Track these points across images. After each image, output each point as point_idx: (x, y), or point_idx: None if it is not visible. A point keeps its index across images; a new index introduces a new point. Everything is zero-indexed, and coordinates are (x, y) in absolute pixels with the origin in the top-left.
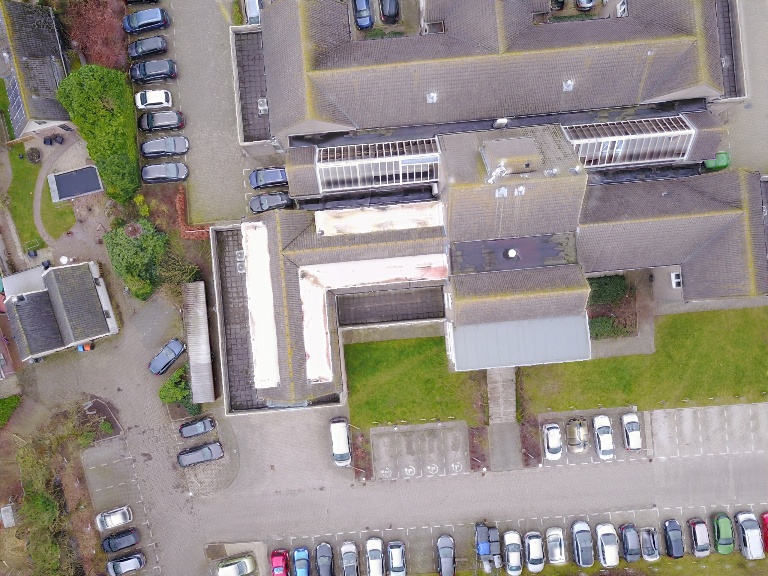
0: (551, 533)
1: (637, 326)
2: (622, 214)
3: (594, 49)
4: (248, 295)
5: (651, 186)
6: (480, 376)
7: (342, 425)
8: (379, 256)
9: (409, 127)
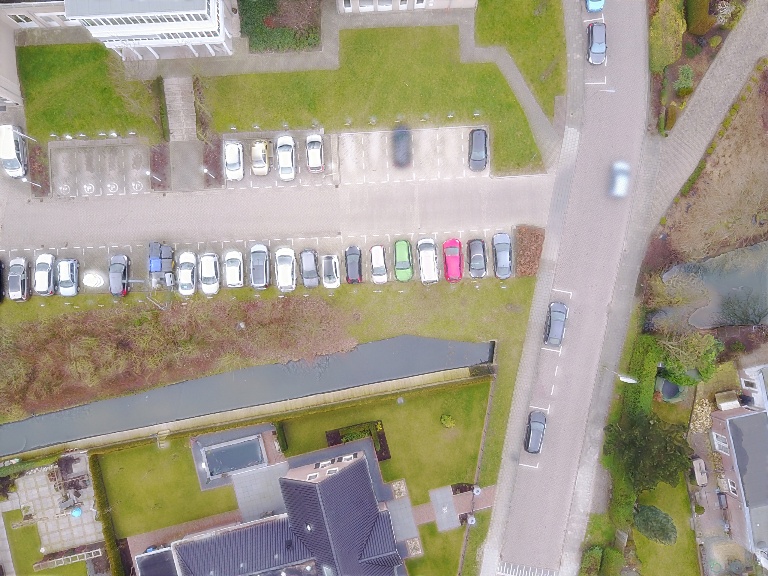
0: (231, 257)
1: (321, 40)
2: None
3: None
4: None
5: None
6: (156, 85)
7: (8, 127)
8: None
9: None
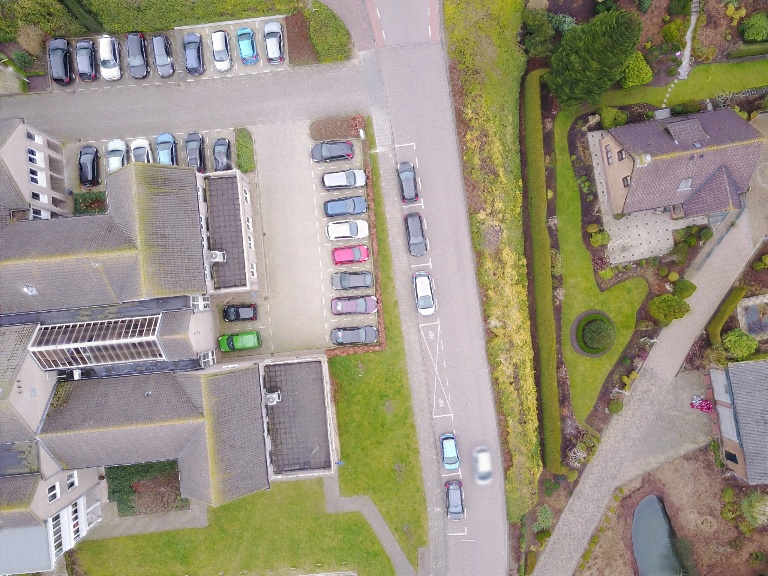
0: None
1: (189, 500)
2: (88, 420)
3: (35, 262)
4: None
5: (143, 382)
6: None
7: None
8: None
9: None
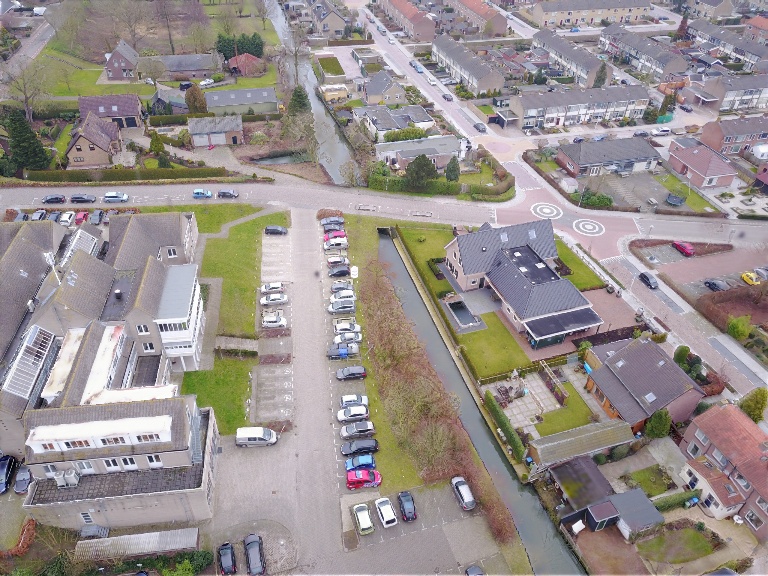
0: (336, 324)
1: None
2: (115, 255)
3: (6, 255)
4: (89, 438)
5: None
6: (219, 353)
7: (239, 430)
8: (92, 359)
9: (7, 351)
